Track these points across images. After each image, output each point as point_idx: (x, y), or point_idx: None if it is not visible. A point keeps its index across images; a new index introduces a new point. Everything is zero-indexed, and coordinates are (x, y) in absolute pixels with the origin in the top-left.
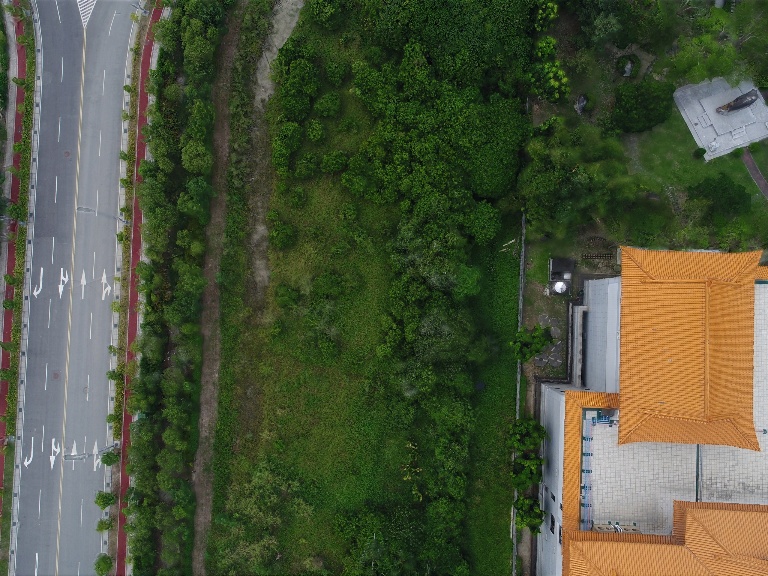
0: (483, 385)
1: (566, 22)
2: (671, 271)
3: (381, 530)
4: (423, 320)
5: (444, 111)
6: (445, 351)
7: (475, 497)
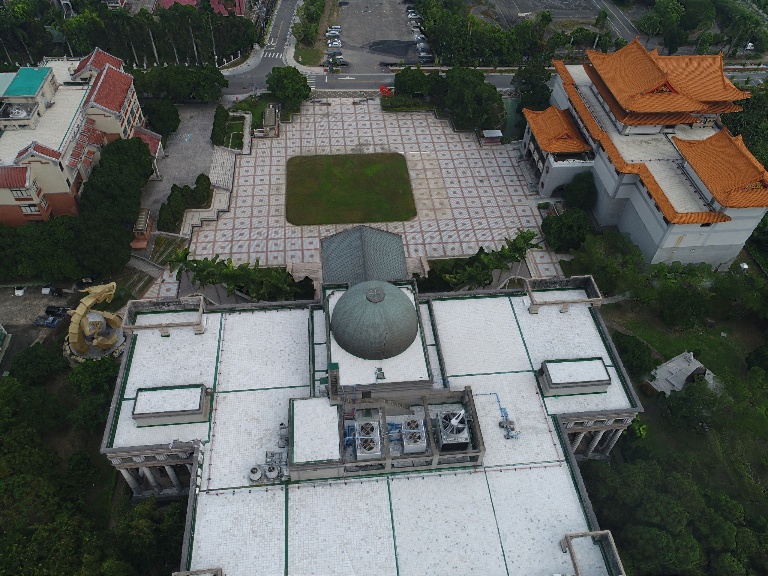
0: None
1: None
2: (767, 194)
3: (763, 160)
4: None
5: None
6: None
7: None
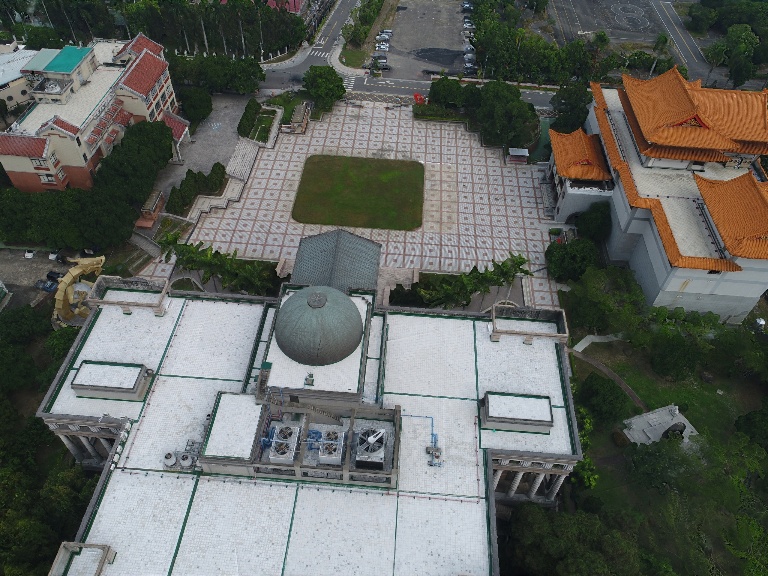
0: None
1: None
2: None
3: None
4: None
5: None
6: None
7: None
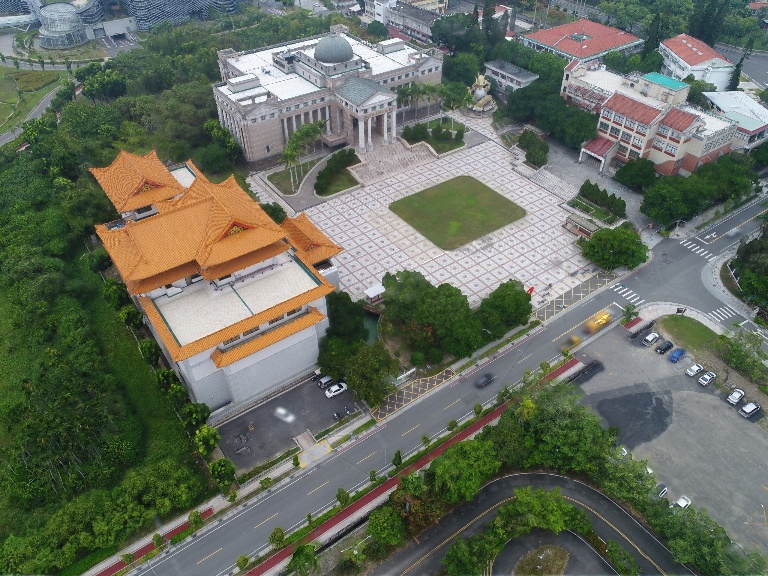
0: (94, 312)
1: (78, 187)
2: None
3: None
4: (28, 285)
5: (14, 221)
6: (47, 287)
7: (110, 354)
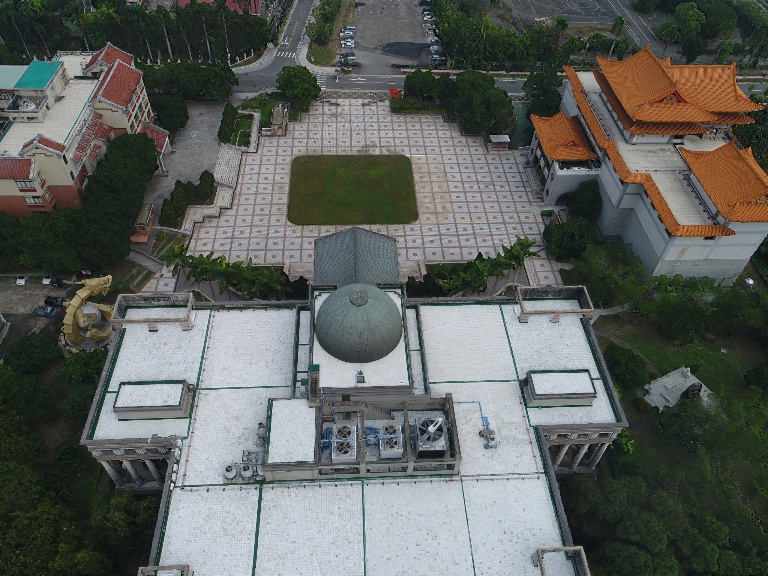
0: None
1: None
2: None
3: None
4: None
5: None
6: None
7: None
